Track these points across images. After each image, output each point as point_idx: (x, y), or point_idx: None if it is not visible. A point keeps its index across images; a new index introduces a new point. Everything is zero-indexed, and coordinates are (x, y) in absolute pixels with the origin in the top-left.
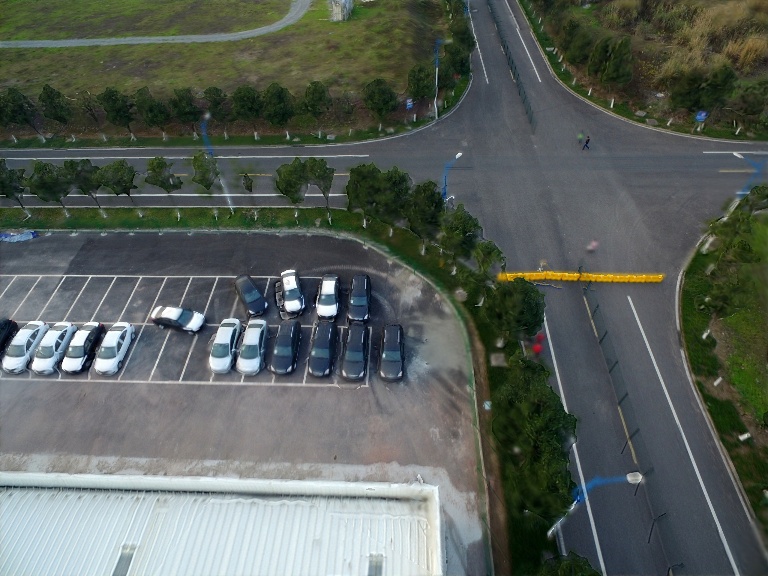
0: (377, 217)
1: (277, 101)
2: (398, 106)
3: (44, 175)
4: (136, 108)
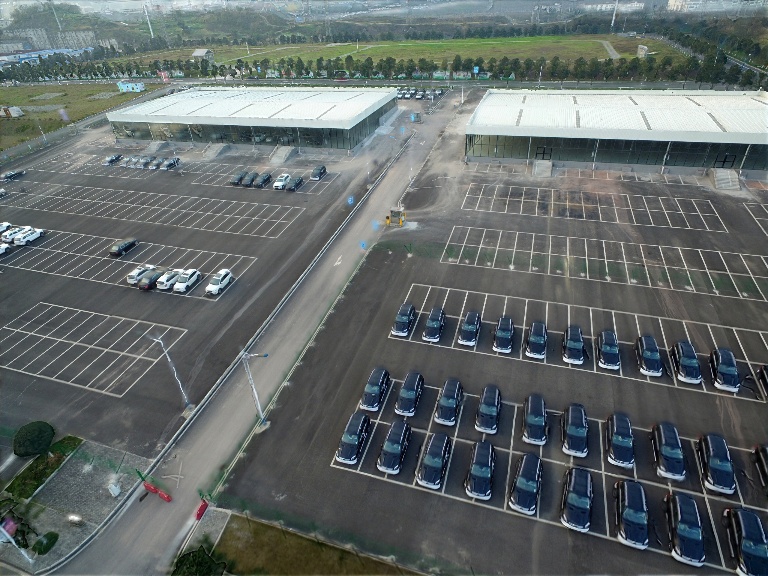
0: (710, 81)
1: (651, 62)
2: (699, 68)
3: (585, 68)
4: (587, 66)
